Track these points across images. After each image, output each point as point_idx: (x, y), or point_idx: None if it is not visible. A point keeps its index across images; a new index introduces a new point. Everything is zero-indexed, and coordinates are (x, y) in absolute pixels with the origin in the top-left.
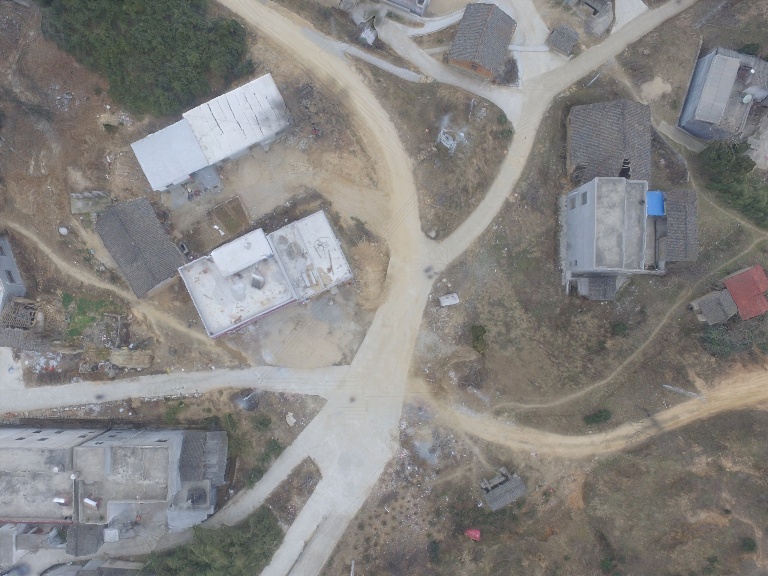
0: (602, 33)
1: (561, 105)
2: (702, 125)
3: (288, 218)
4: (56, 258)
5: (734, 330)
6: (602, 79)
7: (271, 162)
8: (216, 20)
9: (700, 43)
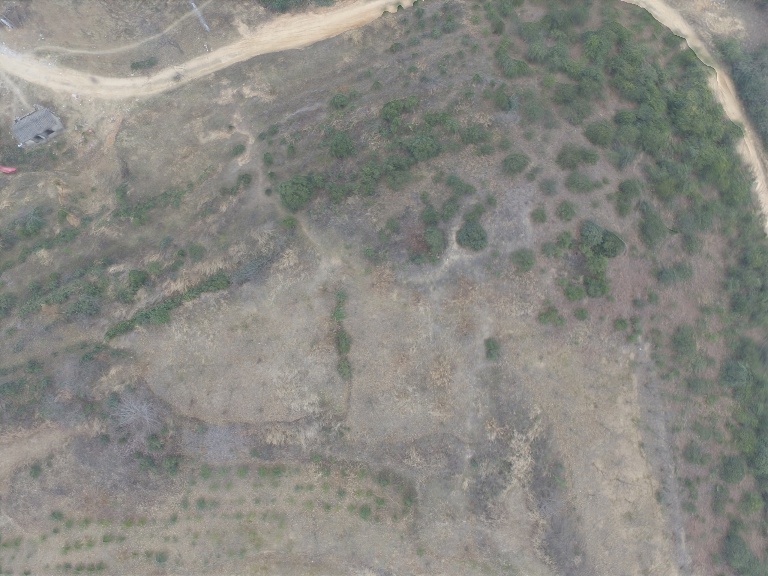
0: None
1: None
2: None
3: None
4: None
5: None
6: None
7: None
8: None
9: None
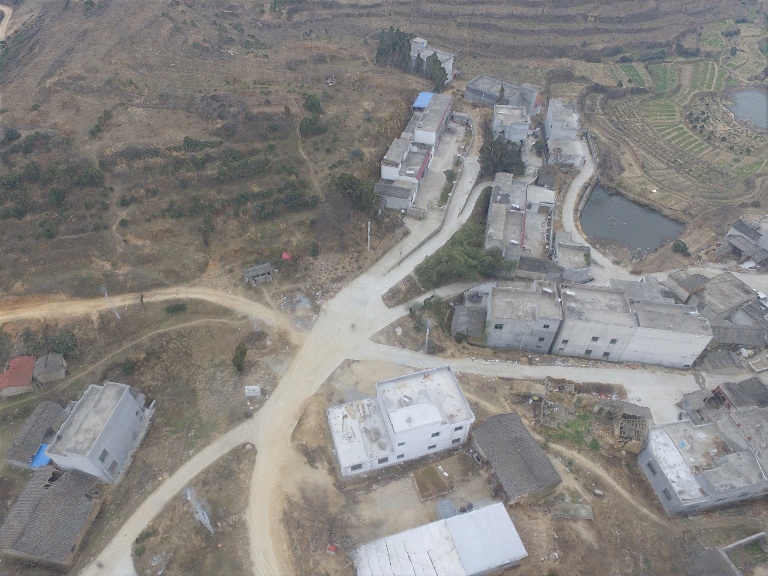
0: None
1: (72, 570)
2: None
3: (377, 479)
4: (609, 480)
5: (46, 353)
6: None
7: (385, 531)
8: None
9: None
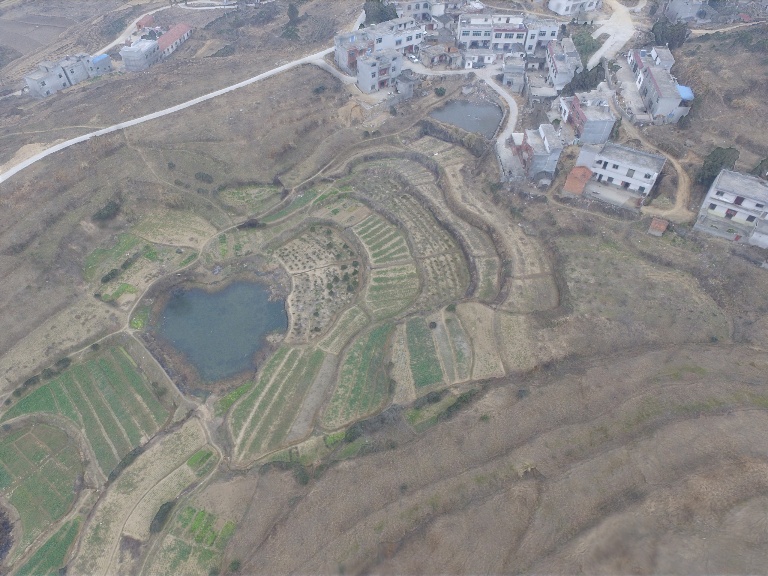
0: None
1: None
2: (702, 4)
3: None
4: None
5: None
6: None
7: None
8: None
9: None
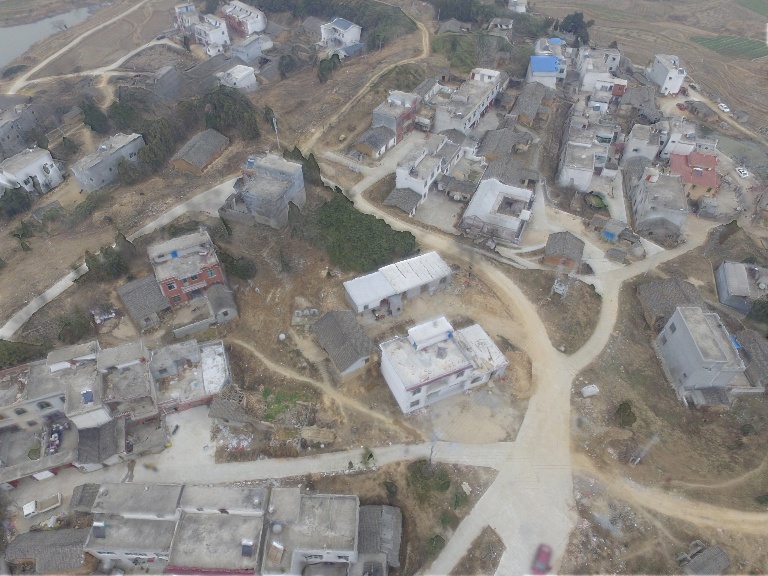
0: (640, 255)
1: (629, 286)
2: (738, 300)
3: None
4: (267, 361)
5: None
6: (651, 276)
7: (435, 301)
8: (398, 231)
9: (710, 262)
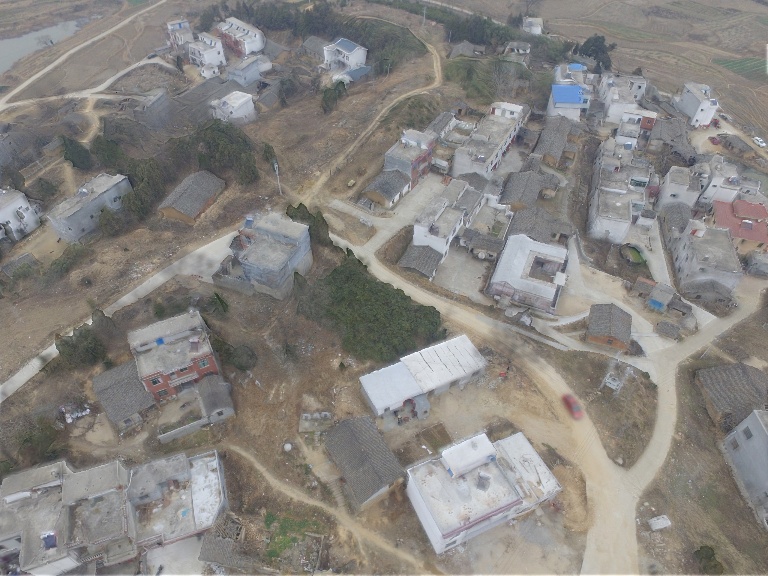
0: (693, 328)
1: (686, 370)
2: None
3: None
4: (269, 476)
5: None
6: (708, 355)
7: (466, 398)
8: (420, 306)
9: None
